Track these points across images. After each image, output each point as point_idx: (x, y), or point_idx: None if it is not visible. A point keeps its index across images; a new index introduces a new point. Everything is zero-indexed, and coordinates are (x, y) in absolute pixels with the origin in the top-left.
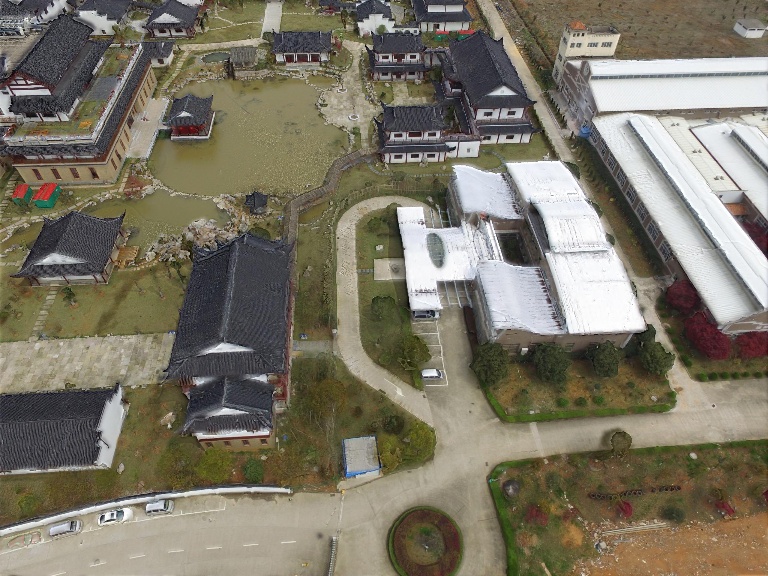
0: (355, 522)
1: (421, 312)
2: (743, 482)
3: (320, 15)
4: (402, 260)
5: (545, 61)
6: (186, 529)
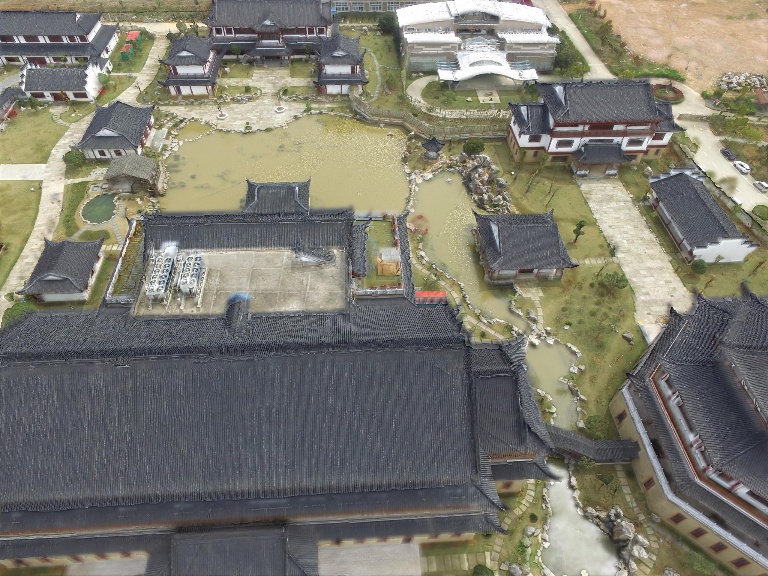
0: None
1: (531, 82)
2: (593, 24)
3: (4, 128)
4: (479, 92)
5: (210, 11)
6: (702, 163)
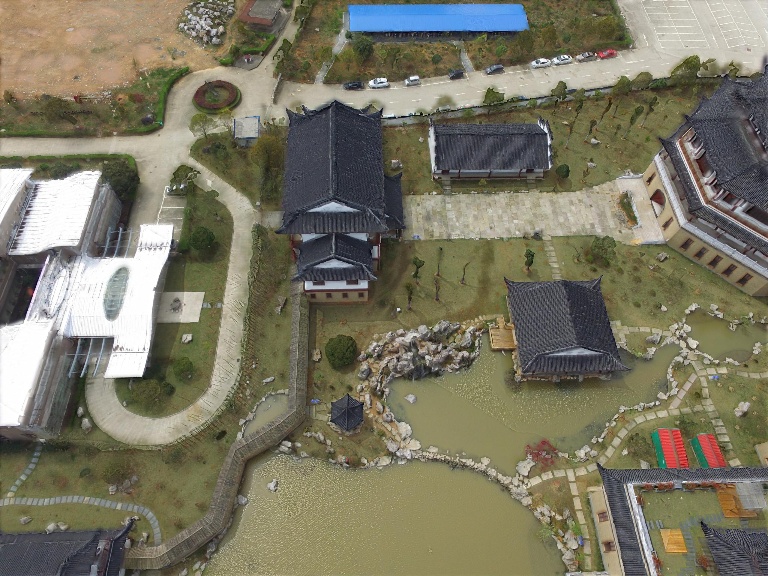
0: (260, 110)
1: None
2: None
3: None
4: (164, 319)
5: None
6: None
